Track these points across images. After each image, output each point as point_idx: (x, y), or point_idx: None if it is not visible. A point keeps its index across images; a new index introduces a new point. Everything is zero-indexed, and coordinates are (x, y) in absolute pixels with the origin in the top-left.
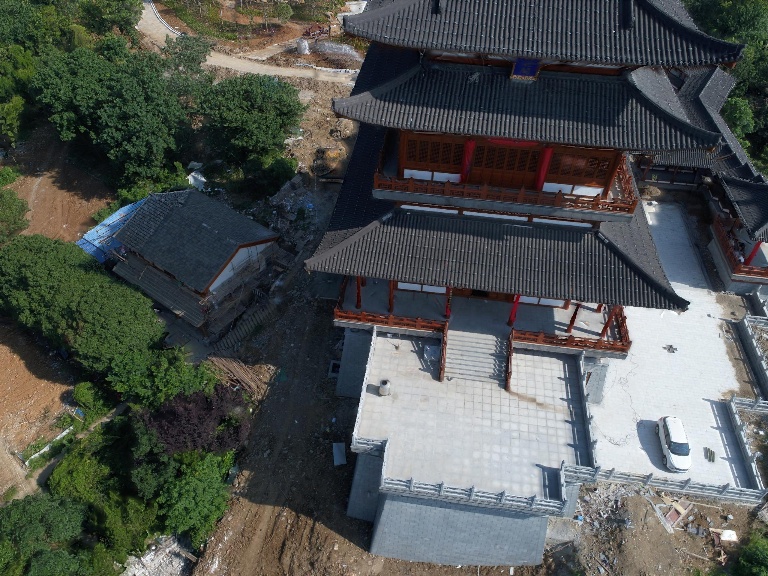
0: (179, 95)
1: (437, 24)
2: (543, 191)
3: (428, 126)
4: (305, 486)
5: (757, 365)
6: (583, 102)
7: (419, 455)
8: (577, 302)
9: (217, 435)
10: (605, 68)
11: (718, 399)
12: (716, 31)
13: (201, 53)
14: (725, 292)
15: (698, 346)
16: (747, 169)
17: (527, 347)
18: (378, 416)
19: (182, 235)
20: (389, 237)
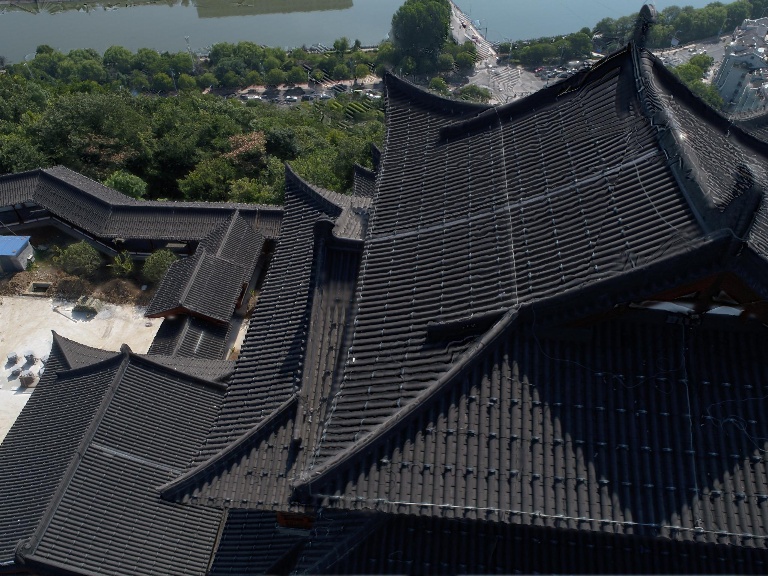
0: None
1: None
2: None
3: None
4: None
5: None
6: None
7: None
8: None
9: None
10: None
11: None
12: None
13: None
14: None
15: None
16: None
17: None
18: None
19: None
20: None
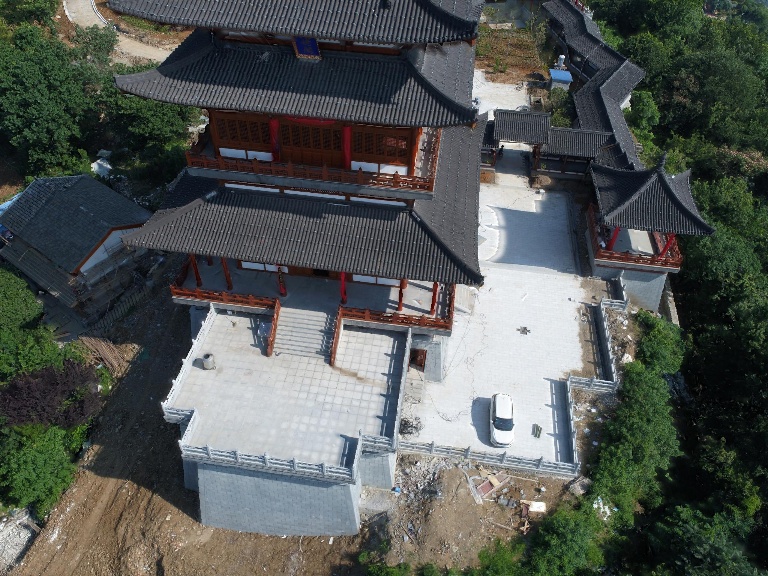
0: (84, 83)
1: (207, 3)
2: (352, 170)
3: (211, 102)
4: (151, 460)
5: (605, 346)
6: (364, 81)
7: (228, 425)
8: (416, 282)
9: (64, 409)
10: (378, 47)
11: (559, 378)
12: (645, 26)
13: (108, 42)
14: (592, 277)
15: (552, 328)
16: (625, 158)
17: (357, 324)
18: (198, 388)
19: (60, 218)
20: (211, 214)
